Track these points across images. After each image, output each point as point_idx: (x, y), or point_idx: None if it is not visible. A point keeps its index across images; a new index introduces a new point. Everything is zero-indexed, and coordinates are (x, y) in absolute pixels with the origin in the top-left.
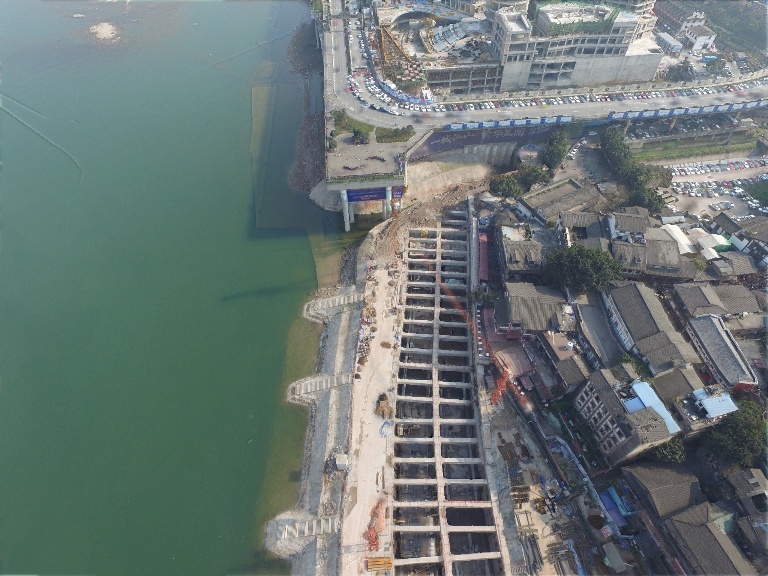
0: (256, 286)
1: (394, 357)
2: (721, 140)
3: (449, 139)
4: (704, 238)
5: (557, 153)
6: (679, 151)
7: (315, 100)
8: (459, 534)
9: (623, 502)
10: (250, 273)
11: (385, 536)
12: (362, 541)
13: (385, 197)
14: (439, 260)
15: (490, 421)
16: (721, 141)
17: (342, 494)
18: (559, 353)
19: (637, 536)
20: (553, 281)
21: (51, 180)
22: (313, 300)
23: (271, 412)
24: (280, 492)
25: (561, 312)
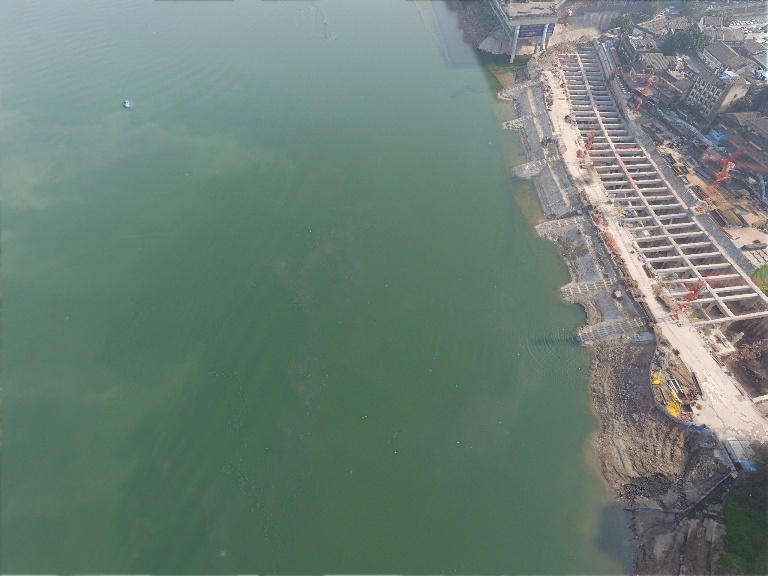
0: (463, 87)
1: (568, 103)
2: (764, 11)
3: (576, 6)
4: (757, 35)
5: (654, 6)
6: (733, 18)
7: (460, 2)
8: (618, 180)
9: (719, 133)
10: (456, 82)
11: (587, 159)
12: (575, 161)
13: (542, 34)
14: (582, 67)
15: (635, 120)
16: (764, 11)
17: (558, 148)
18: (676, 77)
19: (727, 147)
20: (667, 51)
21: (296, 45)
22: (502, 91)
23: (496, 134)
24: (515, 159)
25: (676, 60)
